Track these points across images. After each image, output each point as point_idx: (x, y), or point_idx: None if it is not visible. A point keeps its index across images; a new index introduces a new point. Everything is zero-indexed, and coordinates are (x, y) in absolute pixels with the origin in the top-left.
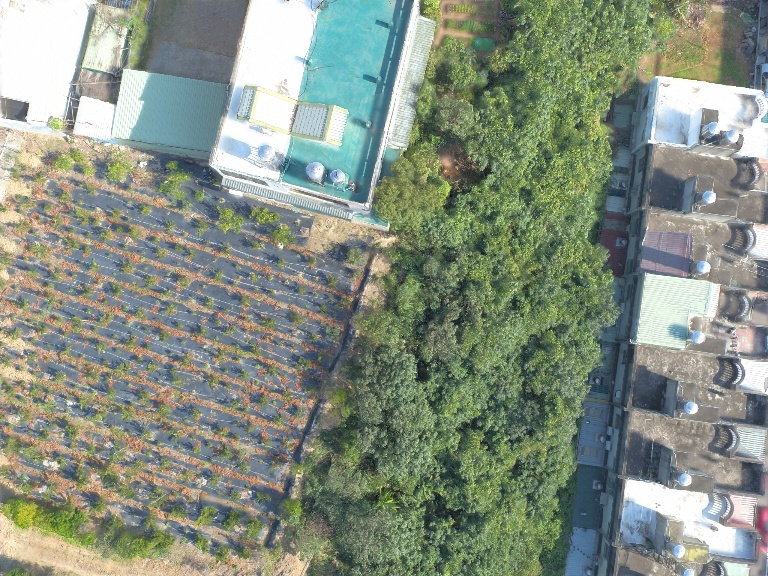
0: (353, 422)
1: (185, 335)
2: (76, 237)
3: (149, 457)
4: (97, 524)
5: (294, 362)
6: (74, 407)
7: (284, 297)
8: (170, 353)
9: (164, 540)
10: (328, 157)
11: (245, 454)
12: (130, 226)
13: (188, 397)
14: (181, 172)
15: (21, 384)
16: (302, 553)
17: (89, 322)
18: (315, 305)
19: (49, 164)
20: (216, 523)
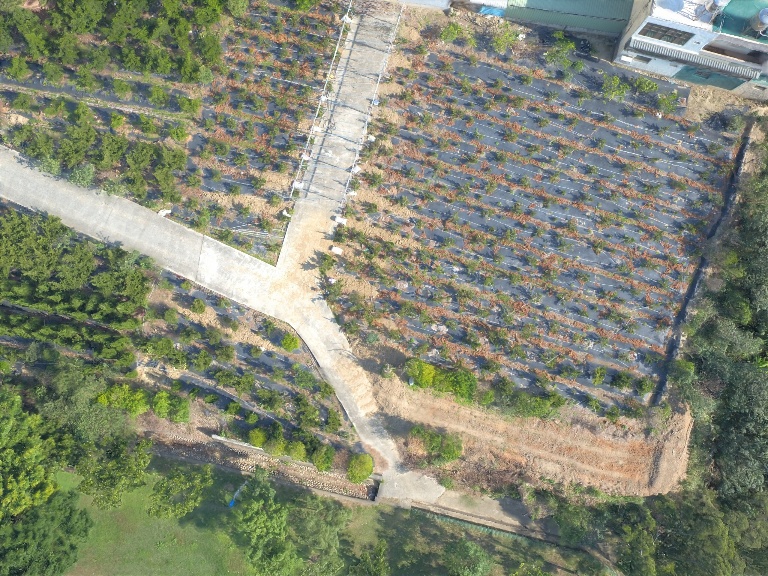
0: (728, 288)
1: (567, 203)
2: (457, 108)
3: (536, 321)
4: (485, 386)
5: (675, 228)
6: (460, 273)
7: (664, 165)
8: (555, 219)
9: (558, 399)
10: (760, 10)
11: (630, 317)
12: (511, 97)
13: (571, 263)
14: (568, 41)
15: (410, 250)
16: (695, 411)
17: (474, 190)
18: (695, 173)
19: (429, 37)
20: (603, 385)
